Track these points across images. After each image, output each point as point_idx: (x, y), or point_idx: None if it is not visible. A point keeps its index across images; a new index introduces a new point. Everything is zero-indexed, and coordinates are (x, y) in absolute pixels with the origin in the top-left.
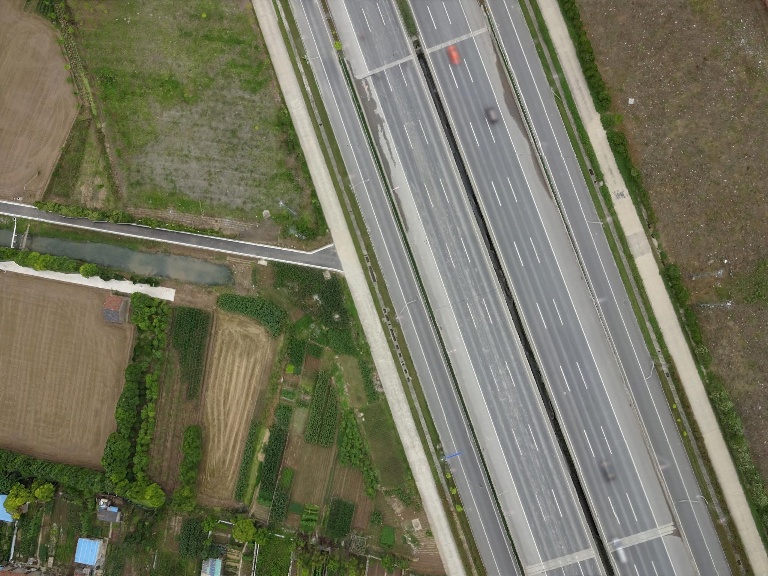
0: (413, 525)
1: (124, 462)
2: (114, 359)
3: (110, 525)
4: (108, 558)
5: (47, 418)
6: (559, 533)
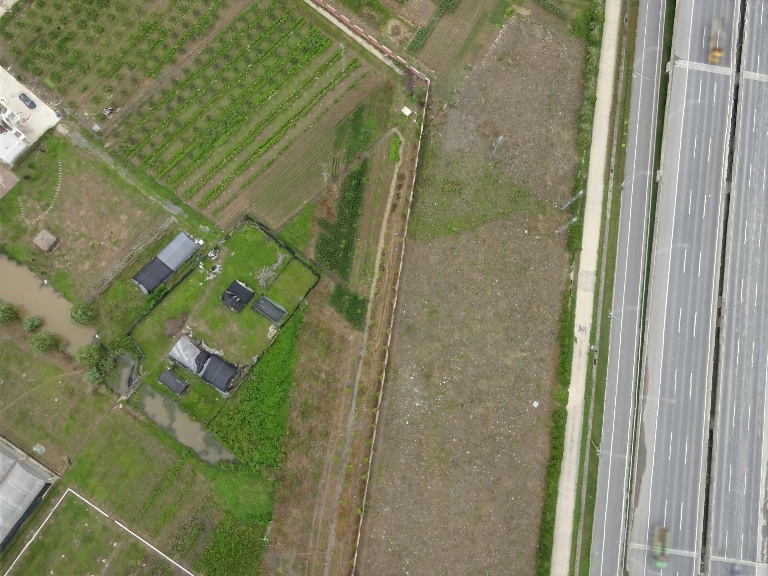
0: None
1: None
2: None
3: None
4: None
5: None
6: (763, 99)
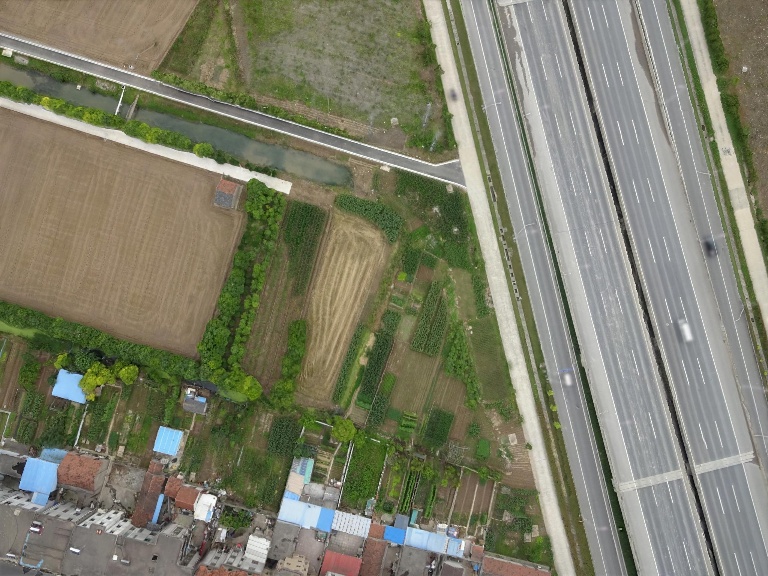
0: (509, 439)
1: (222, 350)
2: (217, 246)
3: (193, 417)
4: (188, 451)
5: (135, 299)
6: (652, 454)
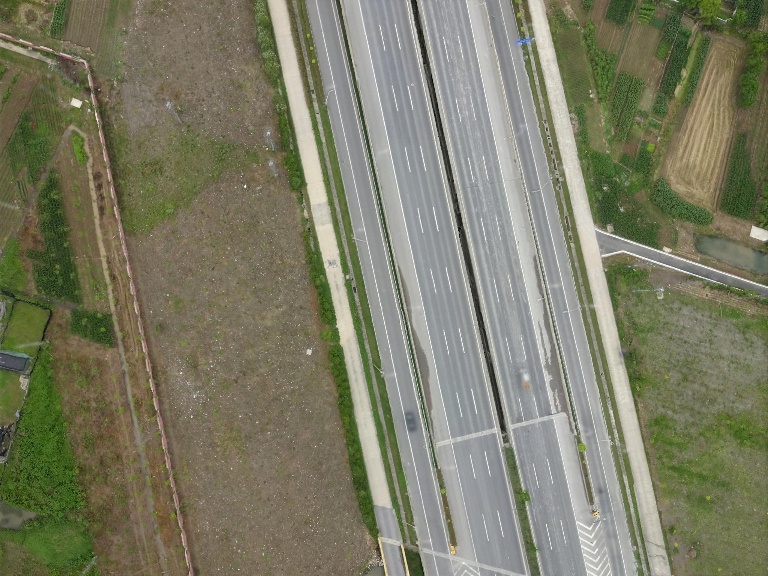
0: None
1: None
2: None
3: None
4: None
5: None
6: None
